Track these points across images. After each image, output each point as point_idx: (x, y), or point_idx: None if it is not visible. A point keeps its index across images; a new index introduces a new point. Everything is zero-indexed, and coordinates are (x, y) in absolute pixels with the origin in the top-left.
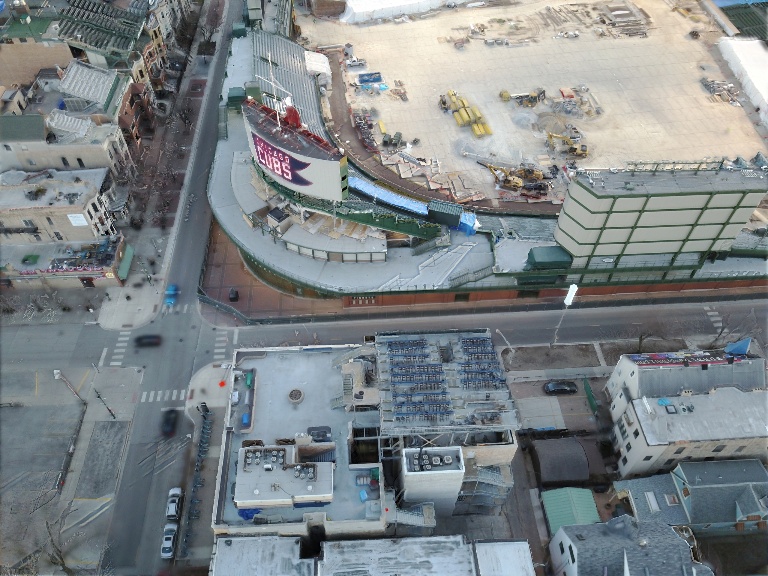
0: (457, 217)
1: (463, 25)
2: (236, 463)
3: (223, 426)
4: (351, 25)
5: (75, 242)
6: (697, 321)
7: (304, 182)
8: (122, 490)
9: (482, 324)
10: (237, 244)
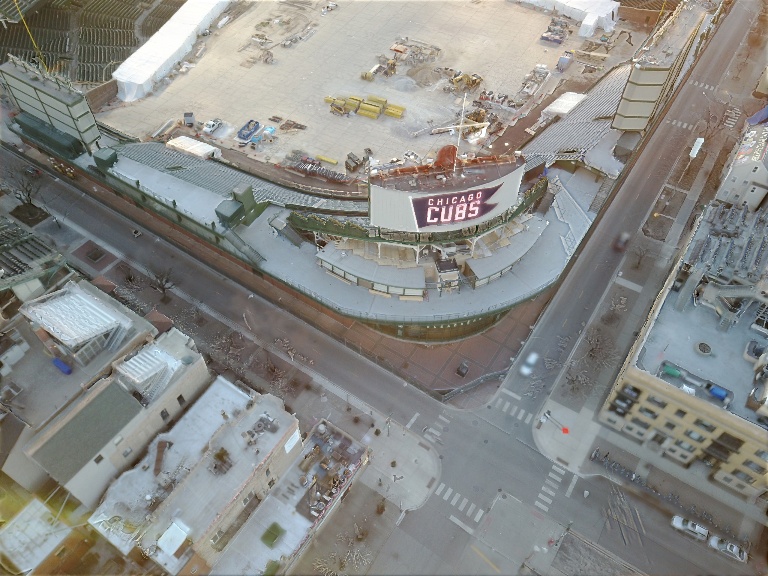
0: None
1: (242, 43)
2: (765, 421)
3: (616, 452)
4: (145, 99)
5: (286, 473)
6: (676, 132)
7: (489, 208)
8: (651, 572)
9: (609, 229)
10: (436, 322)
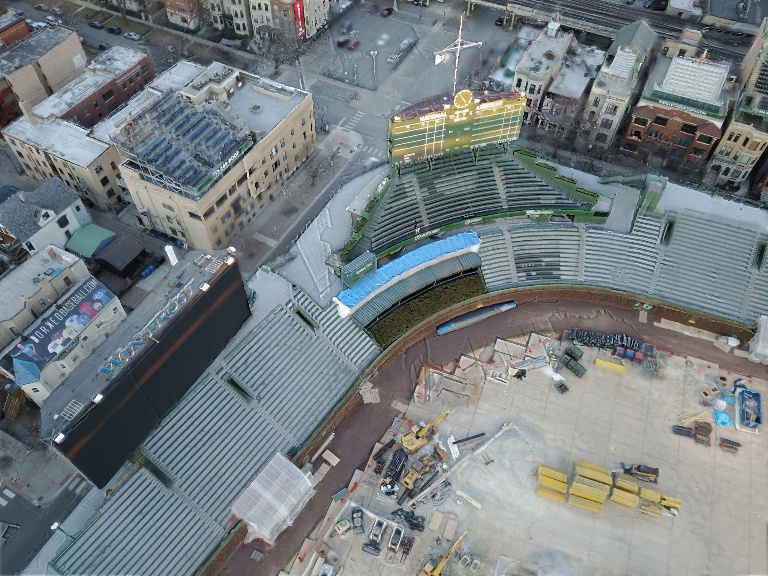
0: None
1: None
2: None
3: None
4: None
5: None
6: None
7: None
8: None
9: None
10: None
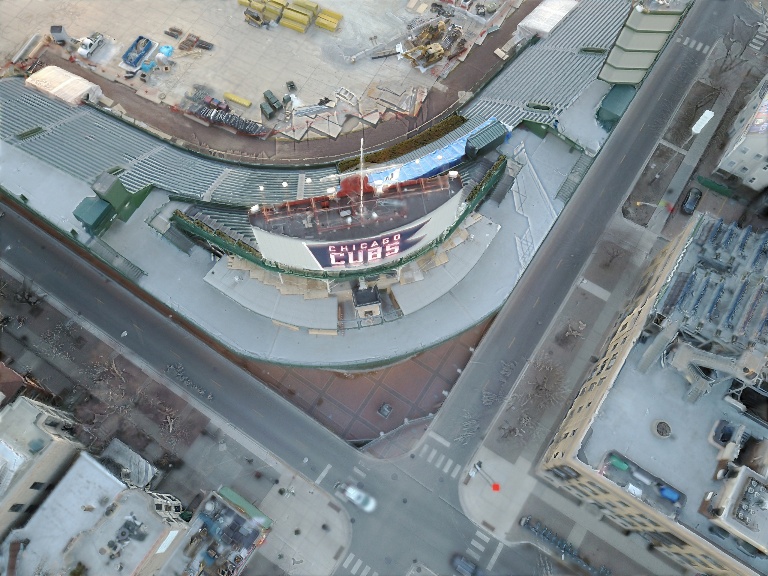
0: (505, 134)
1: None
2: None
3: (549, 514)
4: None
5: (168, 560)
6: (687, 57)
7: (415, 242)
8: None
9: (581, 208)
10: (351, 365)
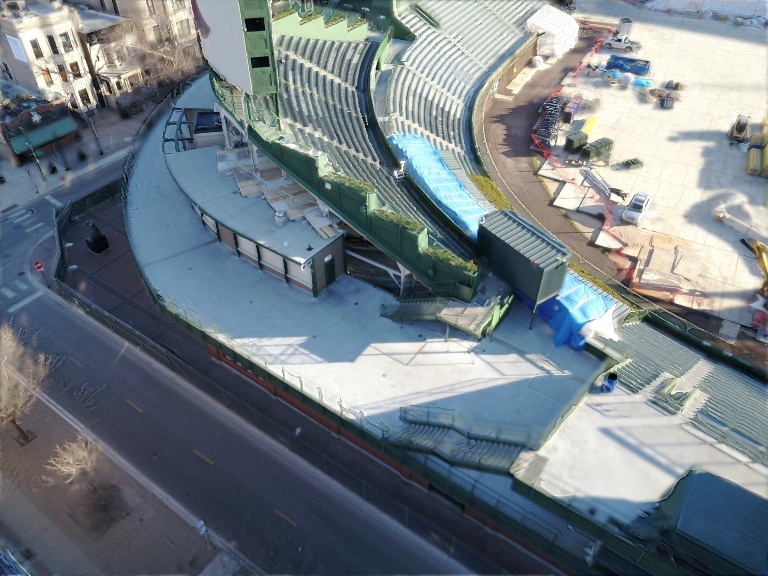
0: (536, 271)
1: None
2: None
3: None
4: (657, 11)
5: (23, 88)
6: None
7: (204, 27)
8: None
9: None
10: None
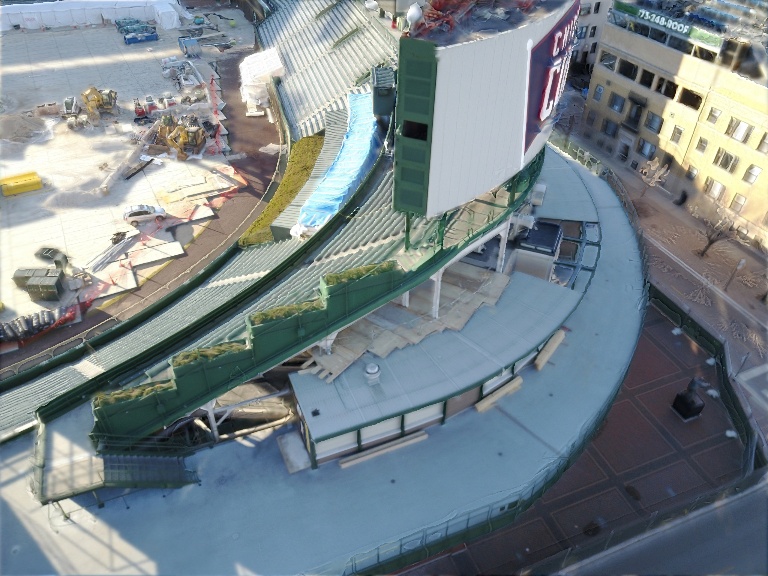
0: None
1: None
2: None
3: None
4: None
5: None
6: None
7: None
8: None
9: None
10: None
